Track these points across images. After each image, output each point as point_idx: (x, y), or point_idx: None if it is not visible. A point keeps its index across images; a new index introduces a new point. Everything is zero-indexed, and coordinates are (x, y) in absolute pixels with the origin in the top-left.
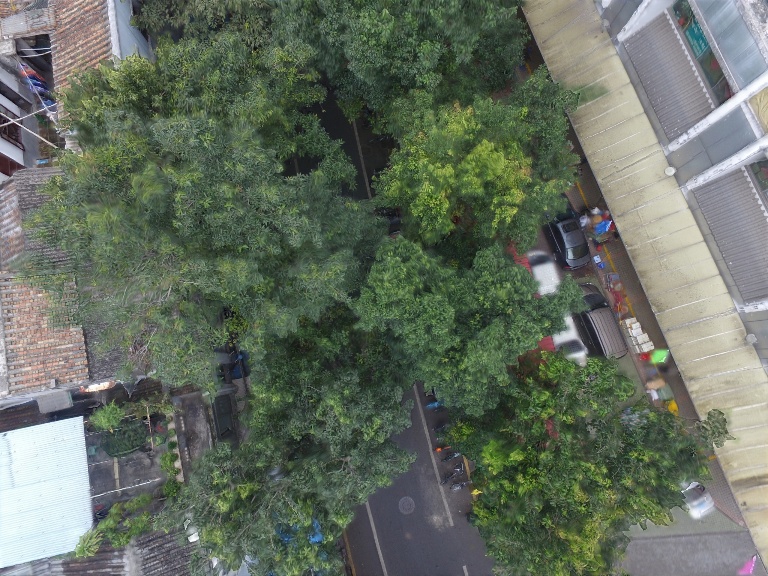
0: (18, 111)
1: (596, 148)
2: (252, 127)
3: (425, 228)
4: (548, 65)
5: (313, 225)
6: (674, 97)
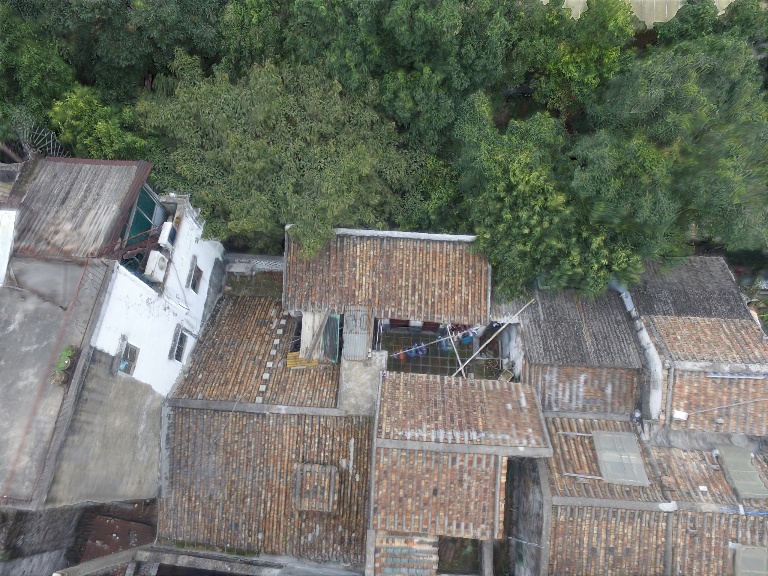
0: None
1: None
2: None
3: None
4: None
5: None
6: None
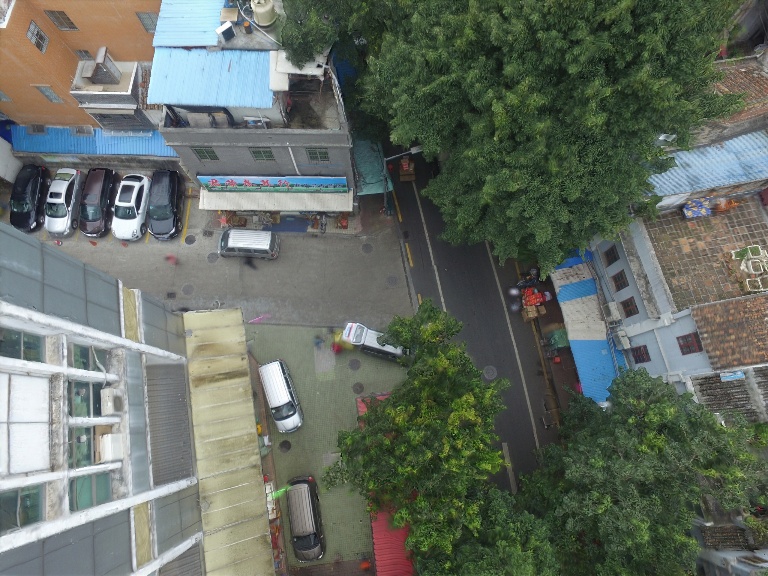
0: None
1: None
2: None
3: None
4: None
5: None
6: None
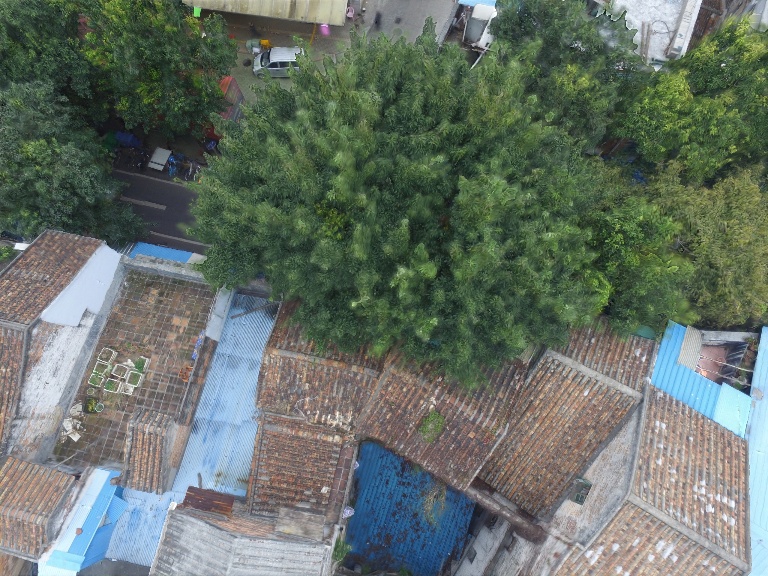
0: None
1: None
2: None
3: None
4: None
5: None
6: None
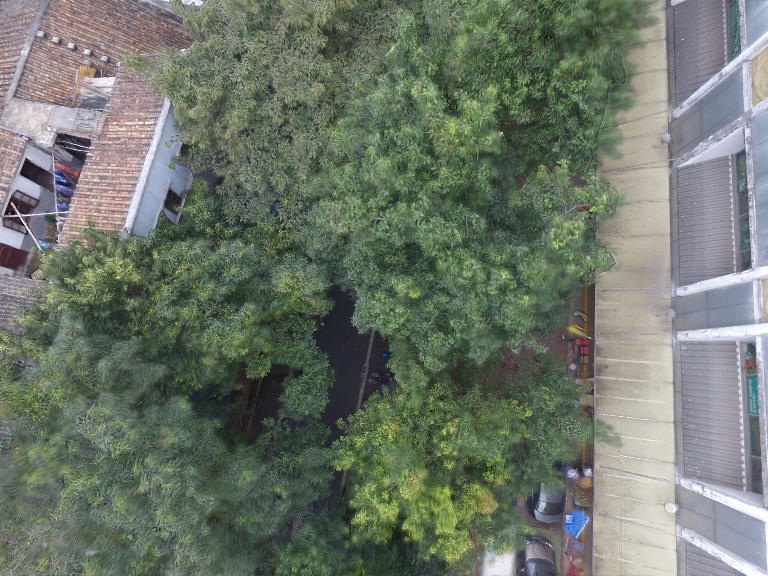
0: (39, 191)
1: (608, 430)
2: (221, 357)
3: (358, 522)
4: (597, 317)
5: (203, 556)
6: (708, 434)
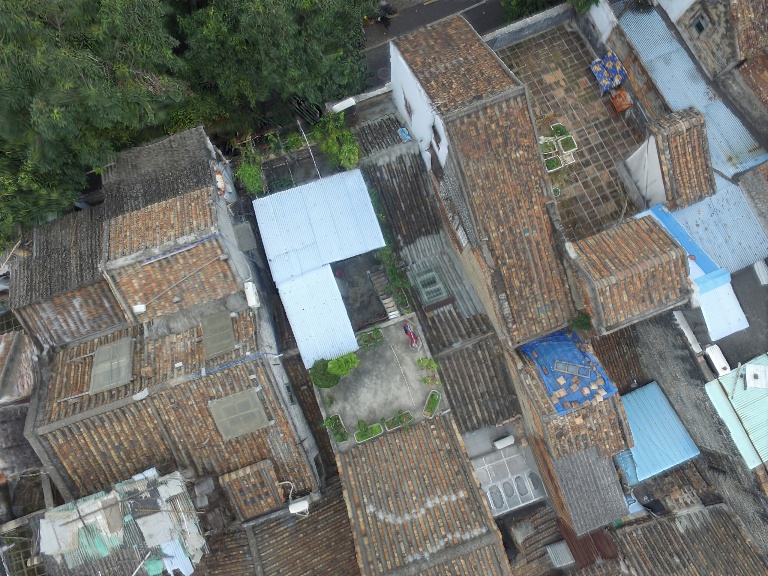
0: None
1: None
2: None
3: None
4: None
5: None
6: None
